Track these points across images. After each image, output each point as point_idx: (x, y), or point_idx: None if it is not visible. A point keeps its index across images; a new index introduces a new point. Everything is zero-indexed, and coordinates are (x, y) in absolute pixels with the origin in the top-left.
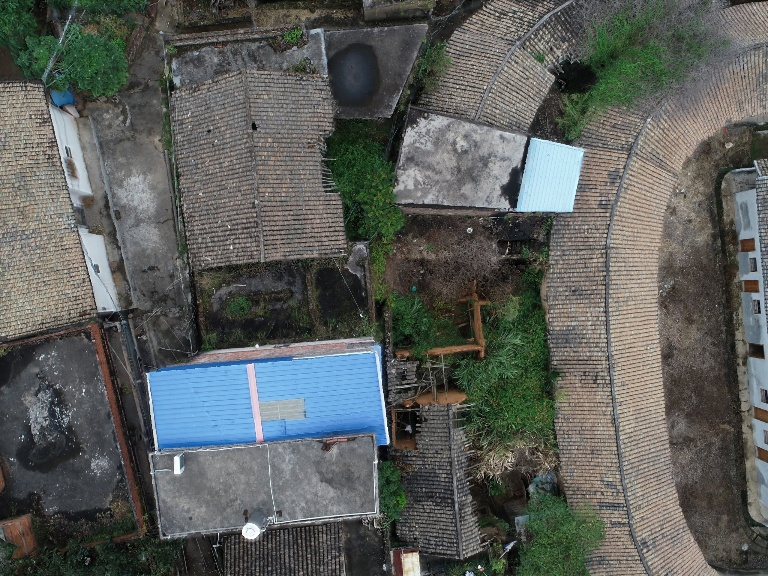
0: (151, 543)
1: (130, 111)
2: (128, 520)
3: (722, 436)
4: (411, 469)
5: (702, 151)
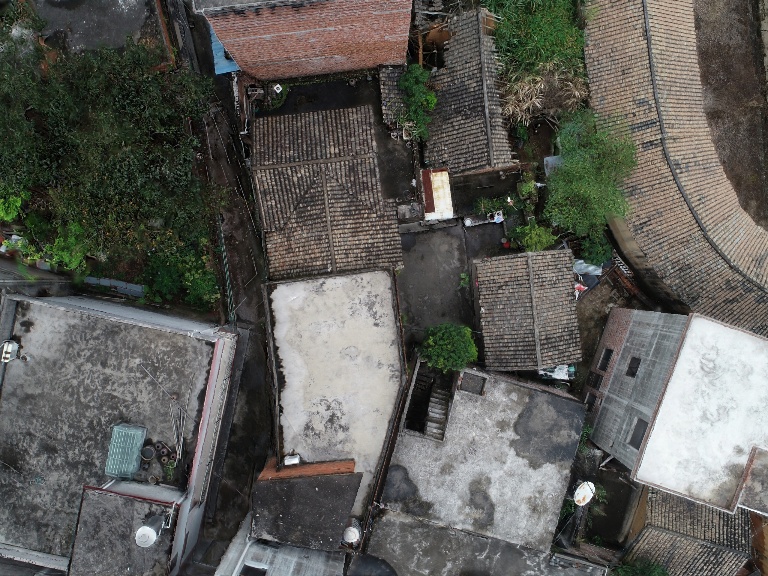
0: (181, 73)
1: None
2: (157, 56)
3: (750, 117)
4: (439, 87)
5: None
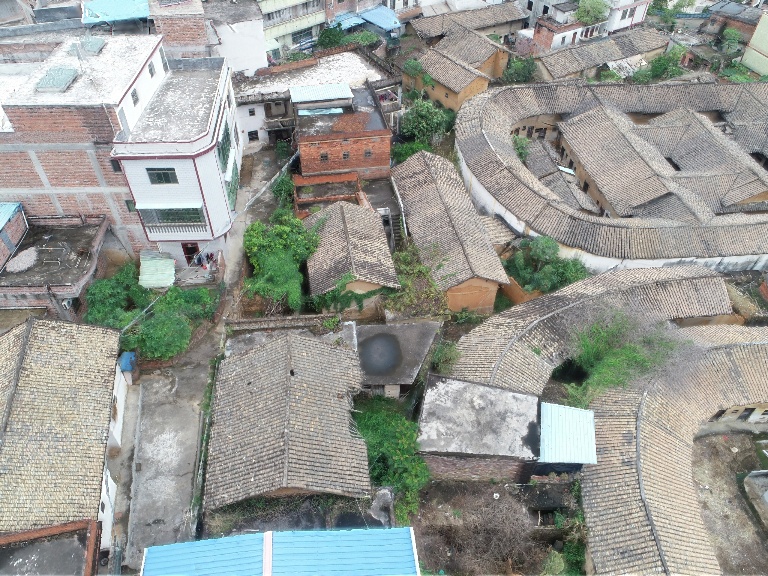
0: None
1: (178, 382)
2: None
3: None
4: None
5: (711, 453)
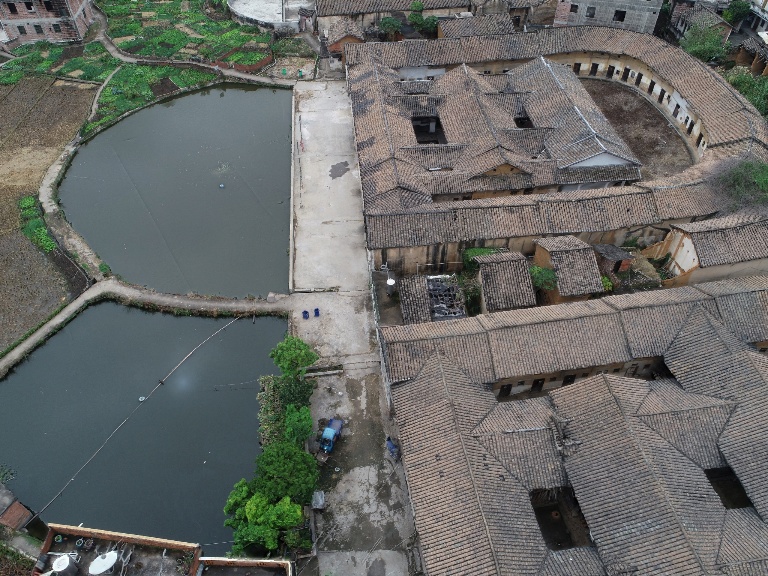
0: None
1: None
2: None
3: None
4: None
5: None
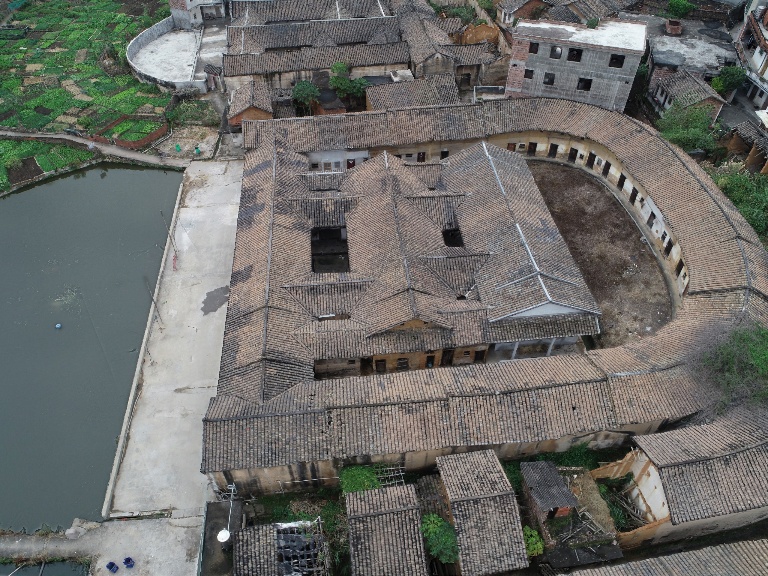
0: None
1: None
2: None
3: None
4: None
5: None
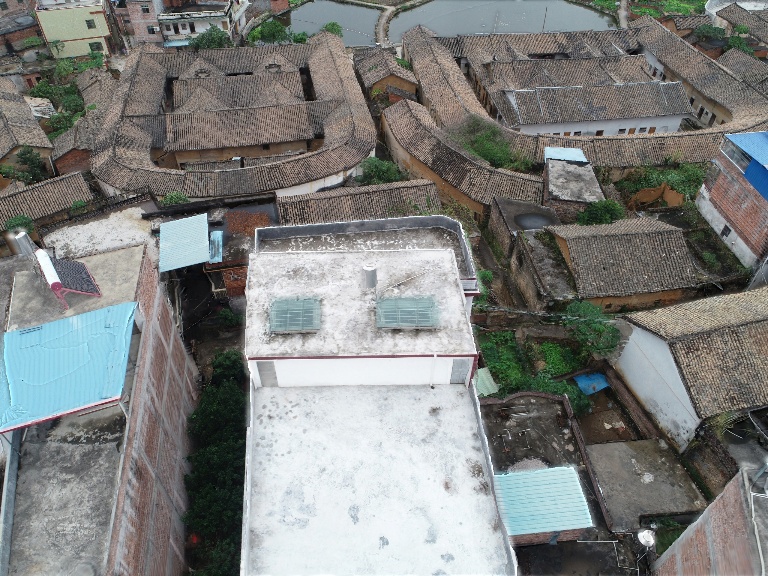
0: None
1: None
2: None
3: None
4: None
5: None
